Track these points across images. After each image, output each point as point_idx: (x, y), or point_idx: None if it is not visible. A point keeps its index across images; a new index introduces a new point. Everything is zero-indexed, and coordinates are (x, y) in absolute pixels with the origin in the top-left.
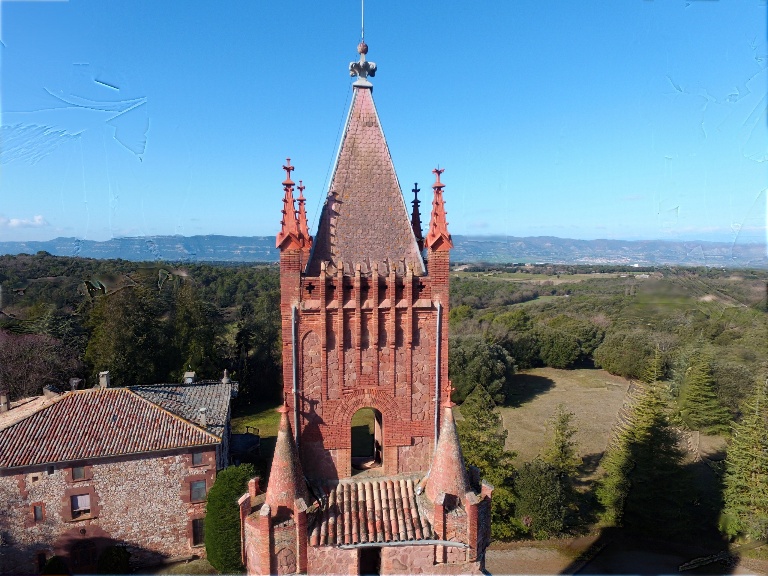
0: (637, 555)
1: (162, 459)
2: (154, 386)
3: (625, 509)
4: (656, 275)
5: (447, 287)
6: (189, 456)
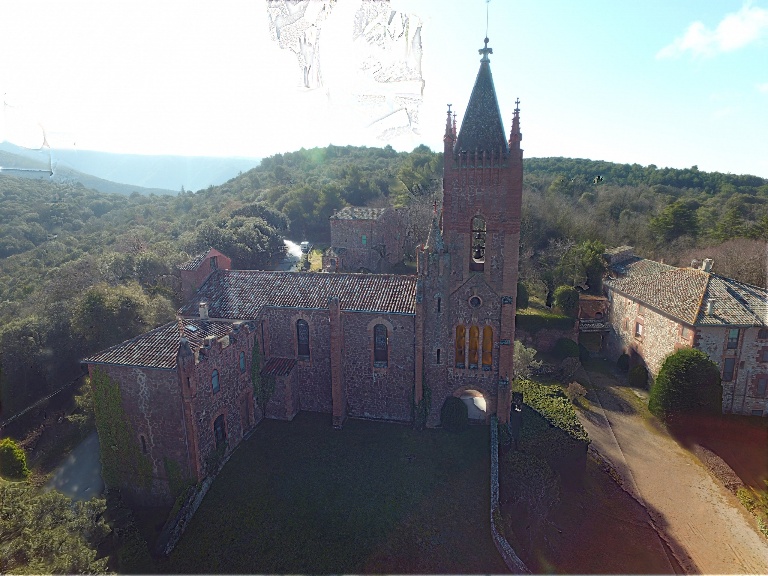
0: None
1: (670, 321)
2: (751, 286)
3: None
4: None
5: None
6: (681, 327)
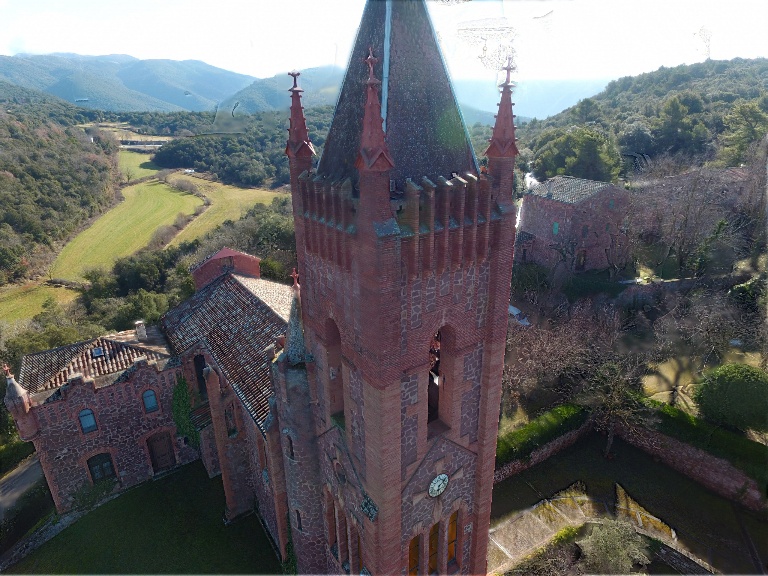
0: None
1: None
2: None
3: None
4: None
5: (293, 192)
6: None
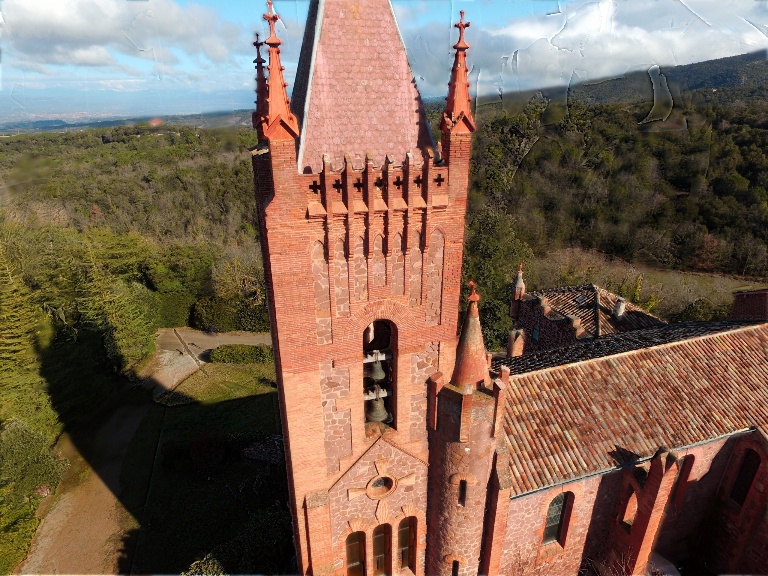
0: (104, 433)
1: None
2: None
3: (62, 413)
4: (35, 149)
5: None
6: None
